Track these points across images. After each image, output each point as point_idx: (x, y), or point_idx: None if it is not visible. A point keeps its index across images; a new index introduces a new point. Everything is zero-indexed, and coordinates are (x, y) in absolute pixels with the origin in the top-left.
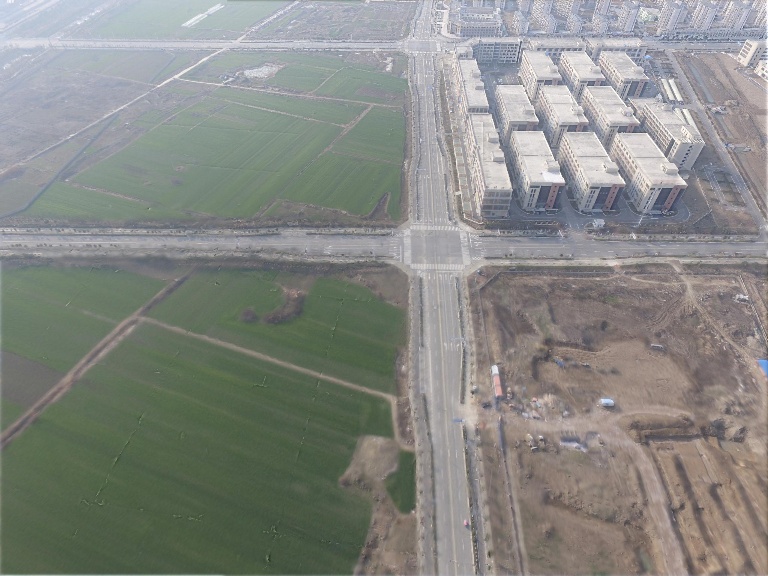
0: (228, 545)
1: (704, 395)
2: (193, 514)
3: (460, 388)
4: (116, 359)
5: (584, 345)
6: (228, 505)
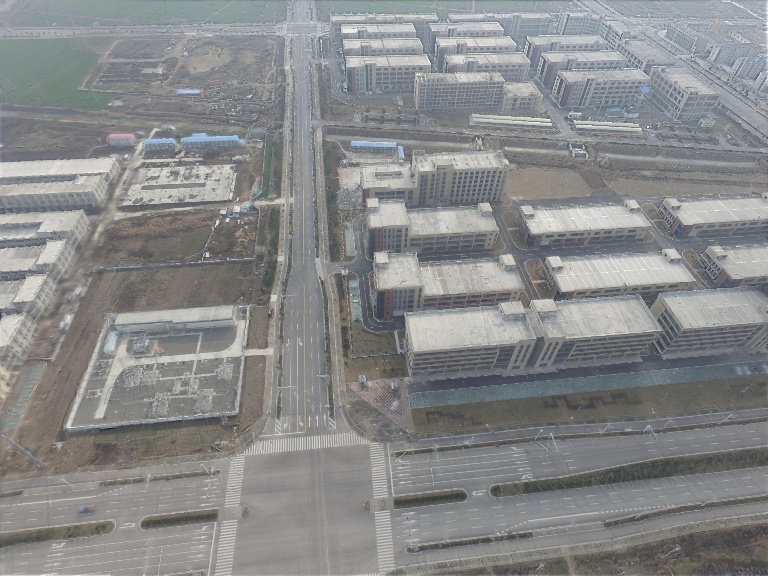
0: (155, 7)
1: (184, 76)
2: (167, 2)
3: None
4: None
5: (220, 53)
6: (168, 5)
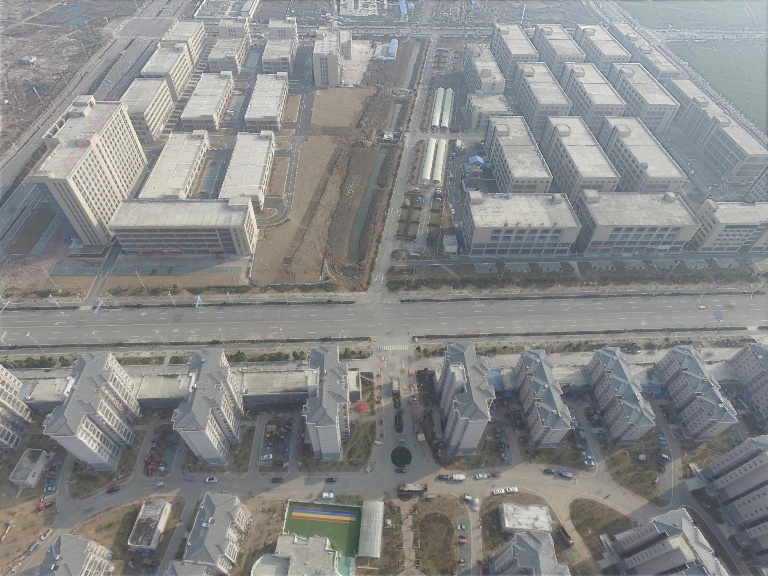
0: None
1: (502, 0)
2: None
3: (595, 2)
4: (737, 8)
5: None
6: None
